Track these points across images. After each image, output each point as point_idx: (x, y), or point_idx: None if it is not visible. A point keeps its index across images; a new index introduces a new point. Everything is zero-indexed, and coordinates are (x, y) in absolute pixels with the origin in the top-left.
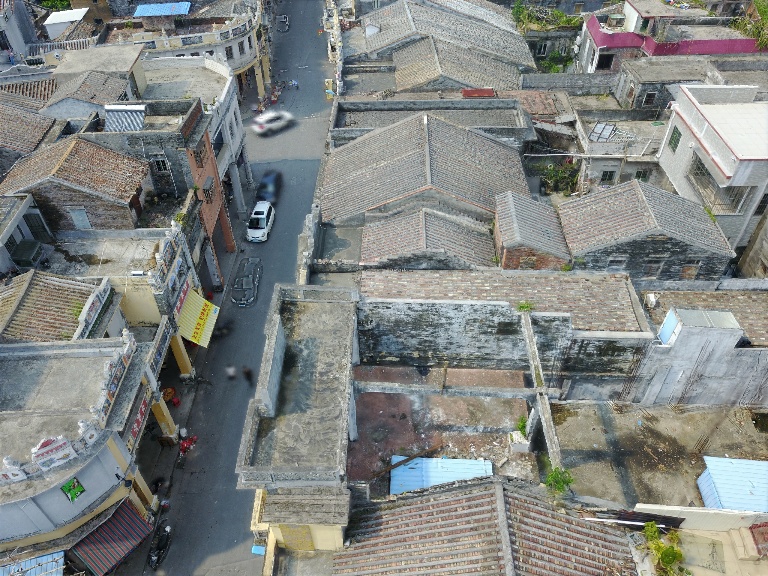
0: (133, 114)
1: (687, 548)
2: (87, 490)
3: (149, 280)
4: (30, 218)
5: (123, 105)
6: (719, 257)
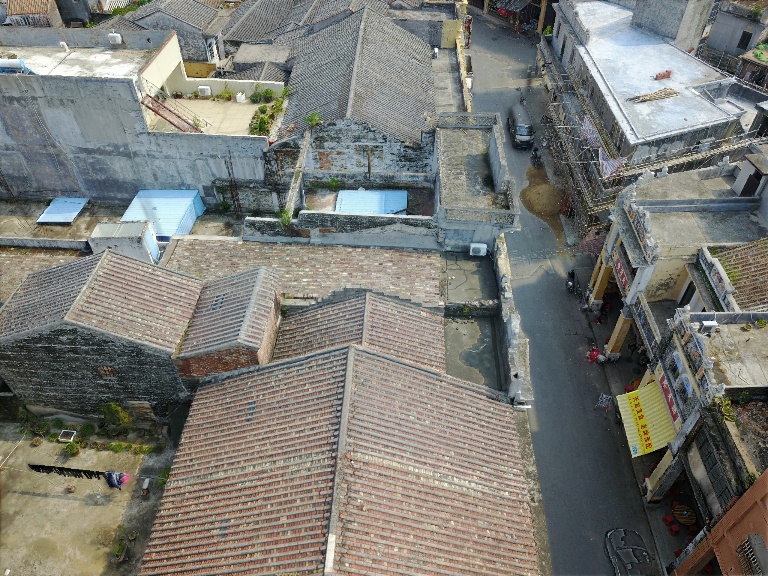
0: None
1: None
2: None
3: None
4: None
5: None
6: None
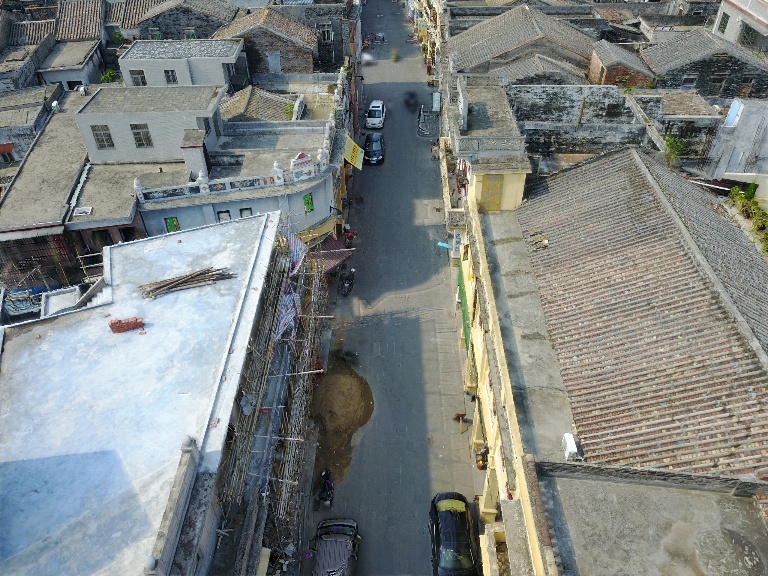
0: None
1: (761, 204)
2: (314, 210)
3: (335, 96)
4: (238, 60)
5: None
6: (767, 75)
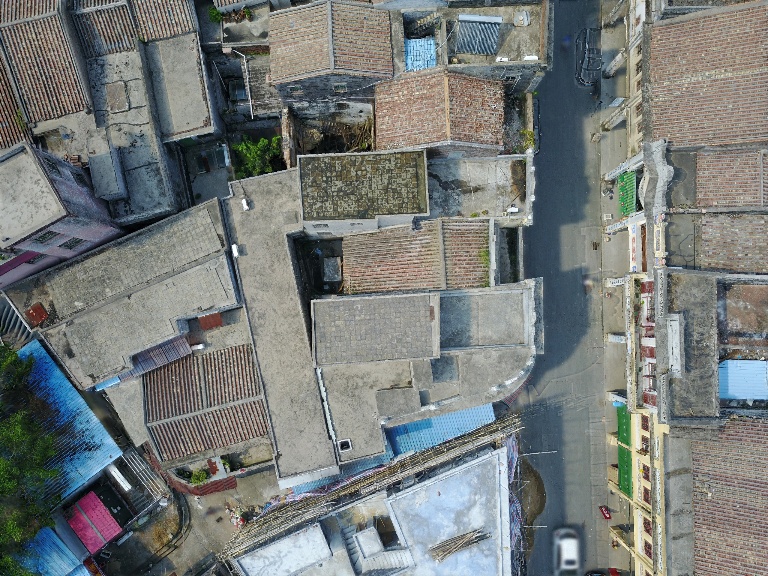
0: (488, 26)
1: None
2: None
3: (528, 221)
4: None
5: (478, 16)
6: None
